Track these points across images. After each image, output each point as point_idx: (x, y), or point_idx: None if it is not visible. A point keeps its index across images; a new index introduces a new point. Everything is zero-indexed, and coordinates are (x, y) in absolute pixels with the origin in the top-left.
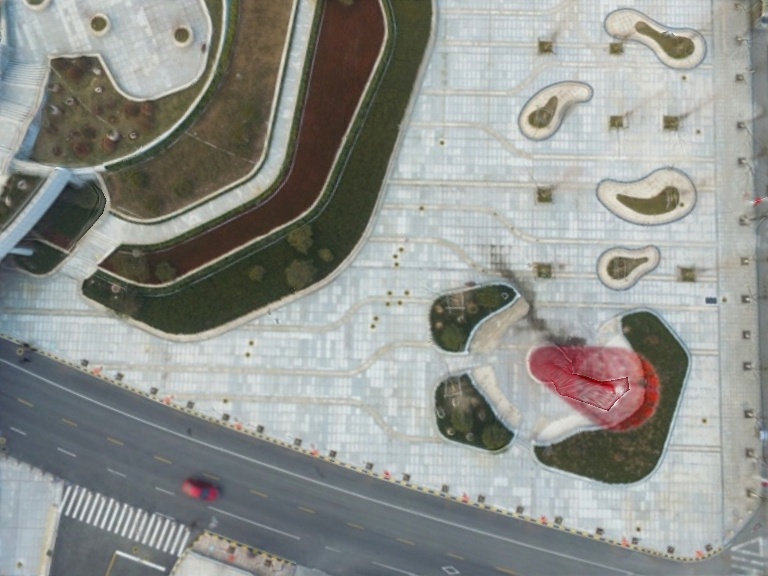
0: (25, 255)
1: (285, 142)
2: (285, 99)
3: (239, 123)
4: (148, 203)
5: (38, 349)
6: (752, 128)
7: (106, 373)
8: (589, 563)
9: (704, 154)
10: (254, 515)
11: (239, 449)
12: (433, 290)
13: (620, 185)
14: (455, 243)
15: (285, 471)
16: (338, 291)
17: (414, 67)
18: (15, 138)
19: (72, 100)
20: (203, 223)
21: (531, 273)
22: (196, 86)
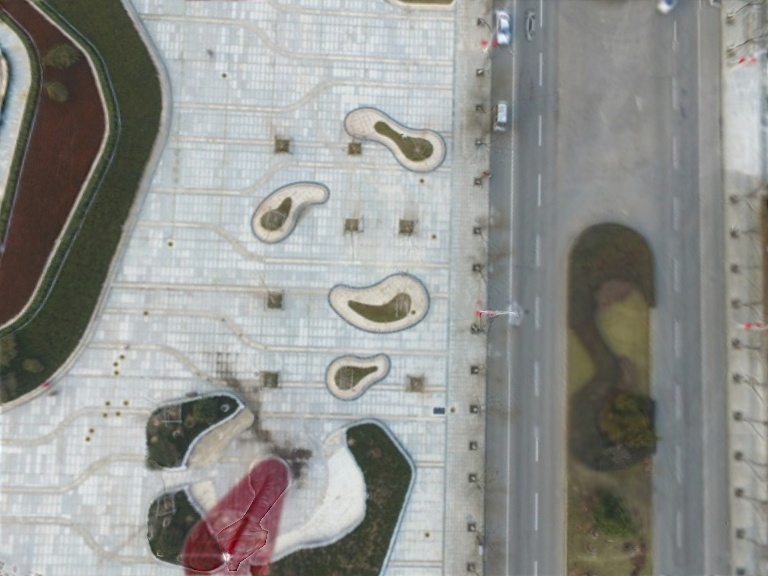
0: None
1: None
2: None
3: None
4: None
5: None
6: (488, 234)
7: None
8: None
9: (439, 260)
10: None
11: None
12: (154, 400)
13: (352, 291)
14: (180, 350)
15: None
16: (52, 401)
17: (139, 165)
18: None
19: None
20: None
21: (257, 382)
22: None
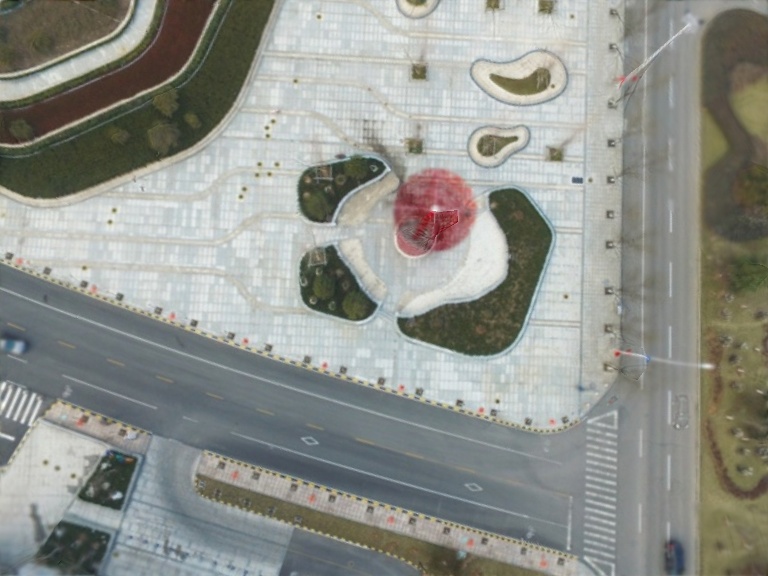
0: None
1: (153, 3)
2: None
3: None
4: (4, 56)
5: None
6: (624, 15)
7: None
8: (448, 434)
9: (577, 38)
10: (110, 384)
11: (97, 317)
12: (303, 162)
13: (494, 65)
14: (328, 117)
15: (144, 340)
16: (207, 161)
17: None
18: None
19: None
20: (64, 81)
21: (402, 148)
22: None
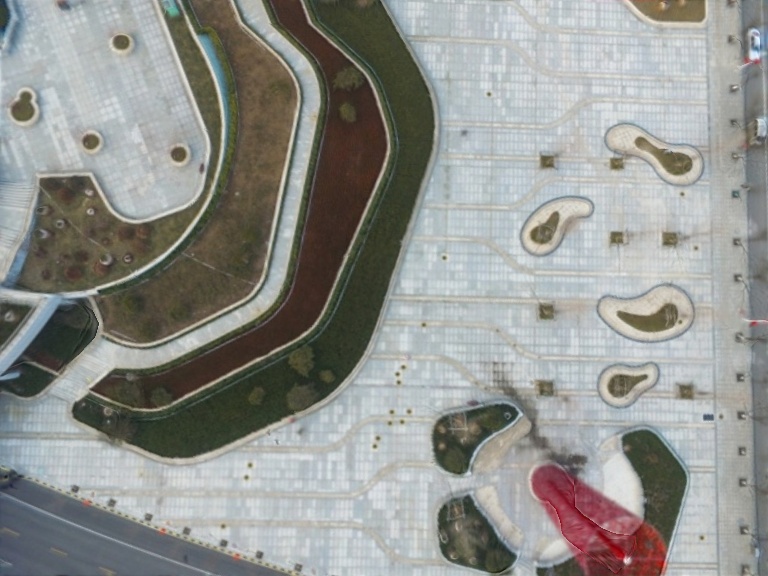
0: (11, 378)
1: (286, 262)
2: (286, 218)
3: (238, 244)
4: (143, 327)
5: (25, 475)
6: (747, 245)
7: (98, 499)
8: None
9: (701, 271)
10: None
11: (238, 575)
12: (435, 409)
13: (620, 302)
14: (457, 360)
15: None
16: (339, 410)
17: (416, 182)
18: (2, 266)
19: (63, 222)
20: (201, 346)
21: (533, 391)
22: (194, 207)
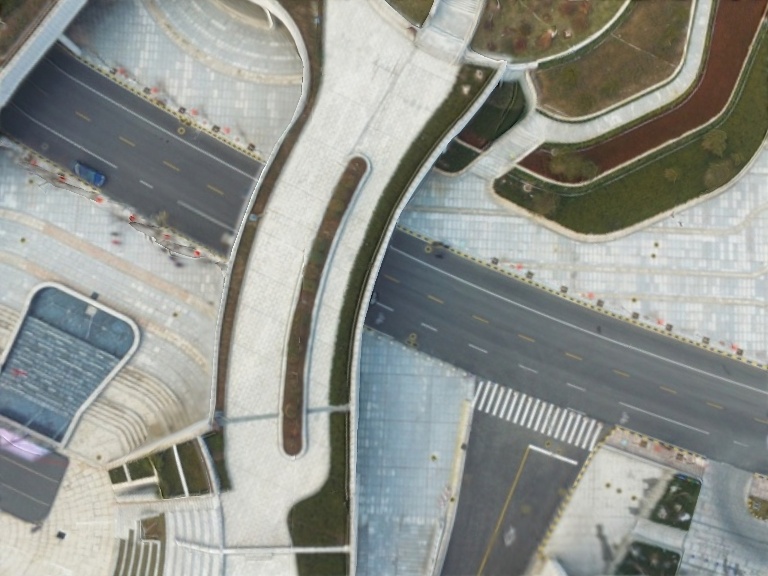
0: (442, 152)
1: (701, 48)
2: (701, 6)
3: (663, 27)
4: (576, 101)
5: (449, 246)
6: None
7: (518, 271)
8: None
9: None
10: (664, 411)
11: (648, 347)
12: None
13: None
14: None
15: (693, 368)
16: (738, 196)
17: None
18: (468, 28)
19: None
20: (623, 124)
21: None
22: None
